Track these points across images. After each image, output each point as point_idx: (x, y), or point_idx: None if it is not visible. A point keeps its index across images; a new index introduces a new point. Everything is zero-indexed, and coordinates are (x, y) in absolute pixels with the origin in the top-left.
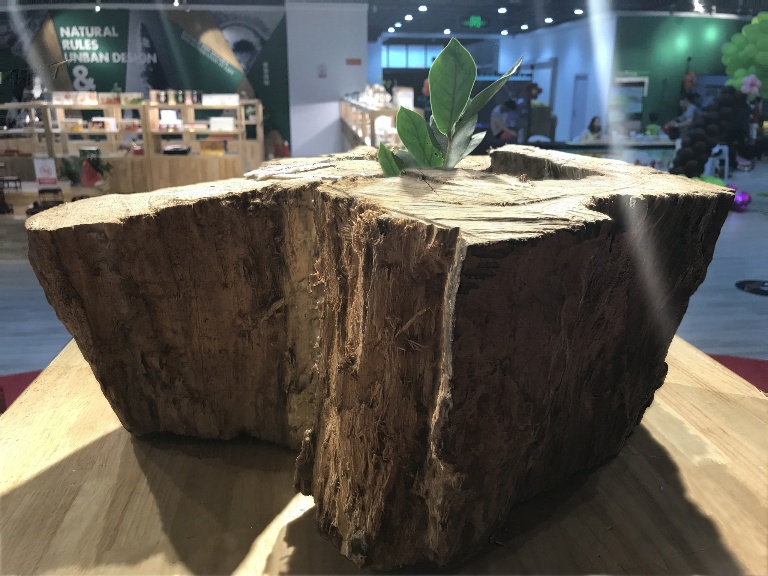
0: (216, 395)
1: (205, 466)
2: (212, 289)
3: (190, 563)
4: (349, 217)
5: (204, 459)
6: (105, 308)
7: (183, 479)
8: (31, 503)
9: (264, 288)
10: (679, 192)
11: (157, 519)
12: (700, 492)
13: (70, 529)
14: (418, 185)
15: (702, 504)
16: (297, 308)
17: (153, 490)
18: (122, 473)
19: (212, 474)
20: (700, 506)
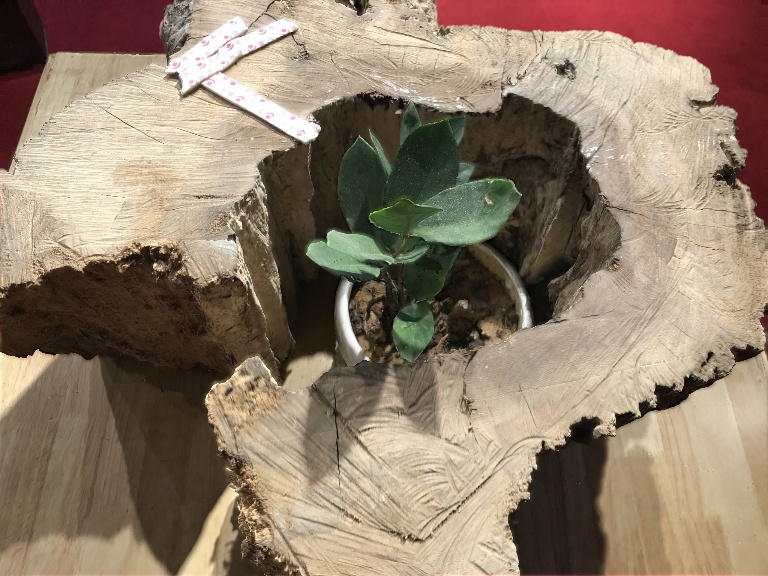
0: (167, 353)
1: (167, 404)
2: (135, 309)
3: (153, 542)
4: (239, 475)
5: (166, 392)
6: (22, 335)
7: (147, 422)
8: (17, 443)
9: (191, 319)
10: (679, 377)
11: (126, 479)
12: (611, 498)
13: (54, 485)
14: (324, 437)
15: (605, 515)
16: (229, 343)
17: (121, 437)
18: (92, 407)
19: (173, 416)
20: (602, 519)
